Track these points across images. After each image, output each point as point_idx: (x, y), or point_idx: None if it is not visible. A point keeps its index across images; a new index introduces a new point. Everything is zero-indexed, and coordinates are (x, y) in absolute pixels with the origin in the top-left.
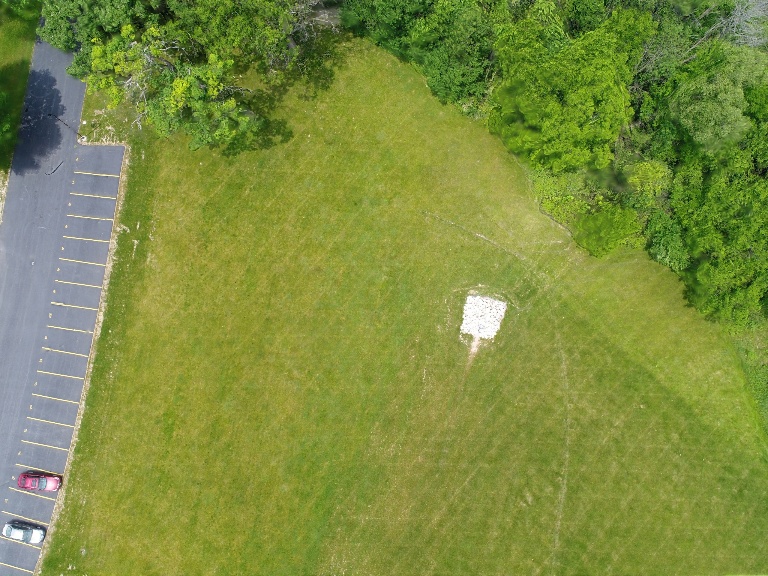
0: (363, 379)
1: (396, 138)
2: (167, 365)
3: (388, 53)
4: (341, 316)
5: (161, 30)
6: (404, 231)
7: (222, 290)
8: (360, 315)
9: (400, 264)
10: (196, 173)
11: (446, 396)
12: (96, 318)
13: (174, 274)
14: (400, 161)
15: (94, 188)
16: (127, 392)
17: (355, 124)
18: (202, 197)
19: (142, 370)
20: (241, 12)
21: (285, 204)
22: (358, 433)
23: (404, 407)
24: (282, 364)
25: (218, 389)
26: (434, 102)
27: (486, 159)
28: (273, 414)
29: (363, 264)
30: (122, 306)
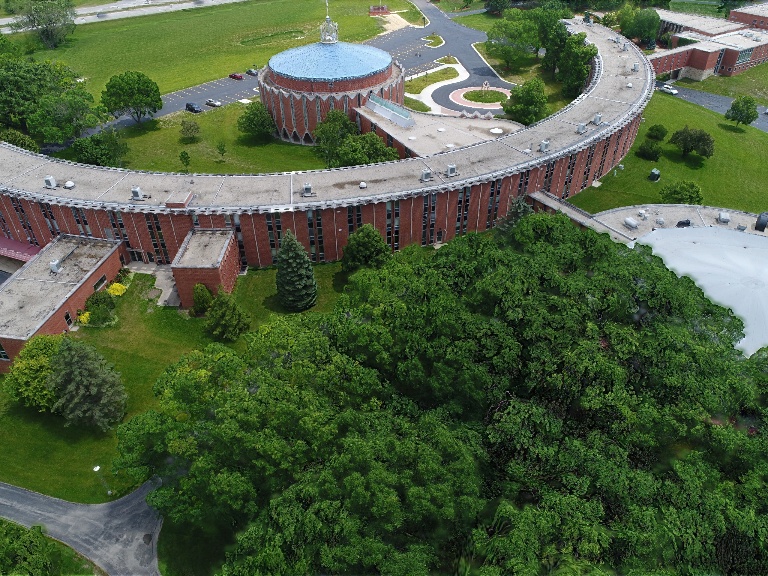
0: None
1: None
2: None
3: None
4: None
5: None
6: None
7: None
8: None
9: None
10: None
11: (110, 74)
12: None
13: None
14: None
15: None
16: None
17: None
18: None
19: None
20: None
21: None
22: None
23: None
24: None
25: None
26: None
27: None
28: None
29: None
30: None
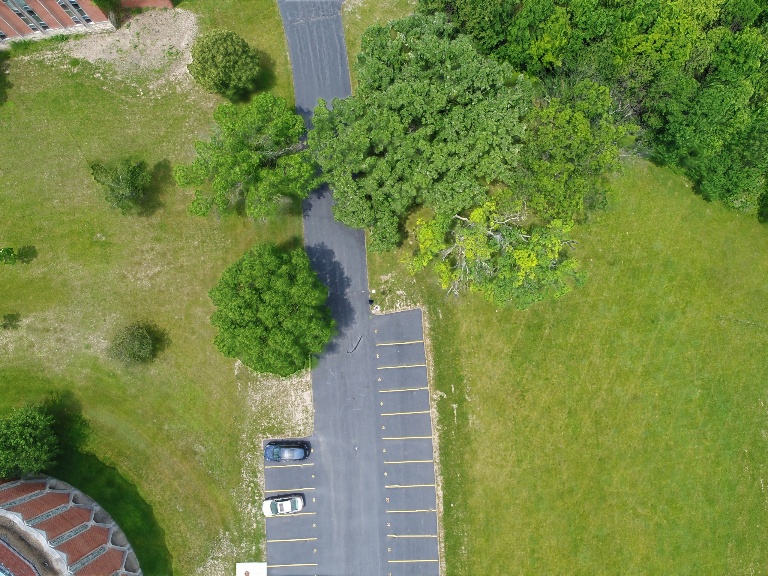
0: (705, 502)
1: (672, 245)
2: (515, 528)
3: (644, 160)
4: (669, 441)
5: (493, 202)
6: (704, 340)
7: (549, 438)
8: (686, 436)
9: (709, 374)
10: (494, 322)
11: None
12: (435, 494)
13: (499, 432)
14: (682, 268)
15: (400, 358)
16: (483, 565)
17: (630, 239)
18: (506, 345)
19: (492, 539)
20: (580, 172)
21: (586, 336)
22: (714, 559)
23: (751, 522)
24: (625, 503)
25: (570, 543)
26: (698, 201)
27: (762, 249)
28: (628, 557)
29: (675, 382)
30: (457, 476)
